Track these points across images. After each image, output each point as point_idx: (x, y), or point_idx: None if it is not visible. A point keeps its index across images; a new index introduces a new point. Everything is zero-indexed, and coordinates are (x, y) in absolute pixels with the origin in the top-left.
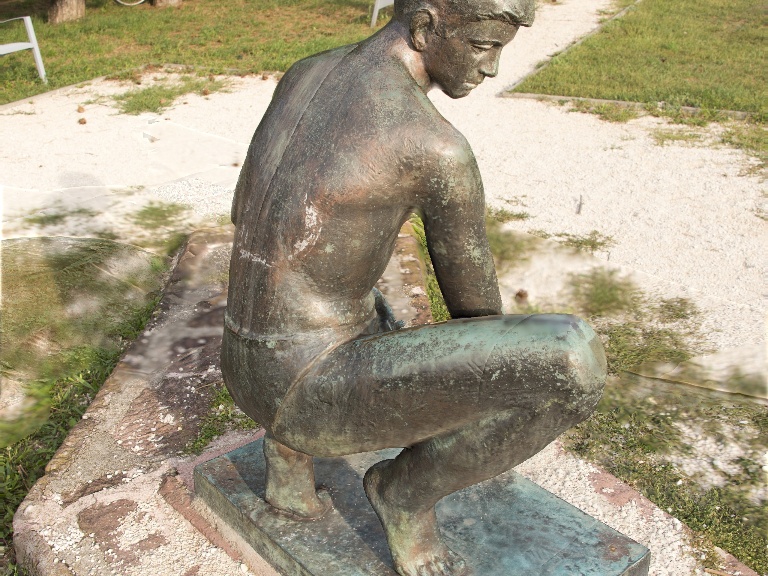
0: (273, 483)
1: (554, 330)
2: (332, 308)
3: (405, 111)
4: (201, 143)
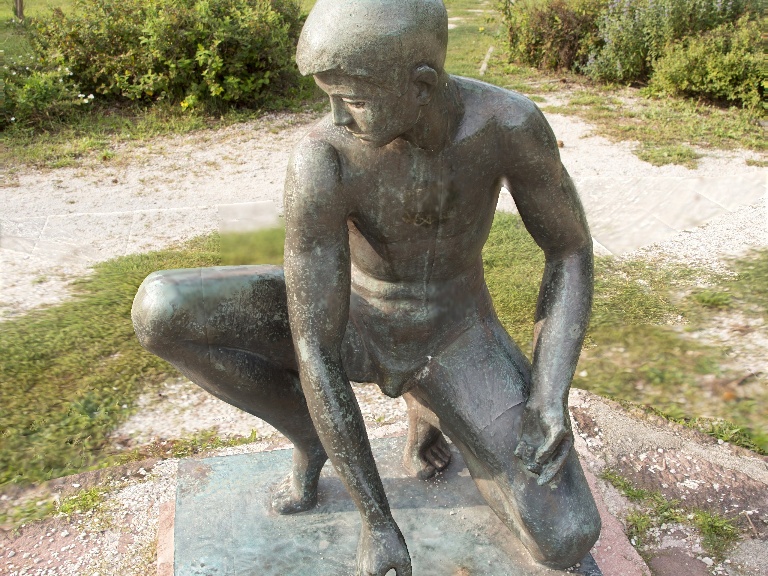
0: None
1: (168, 270)
2: None
3: None
4: None
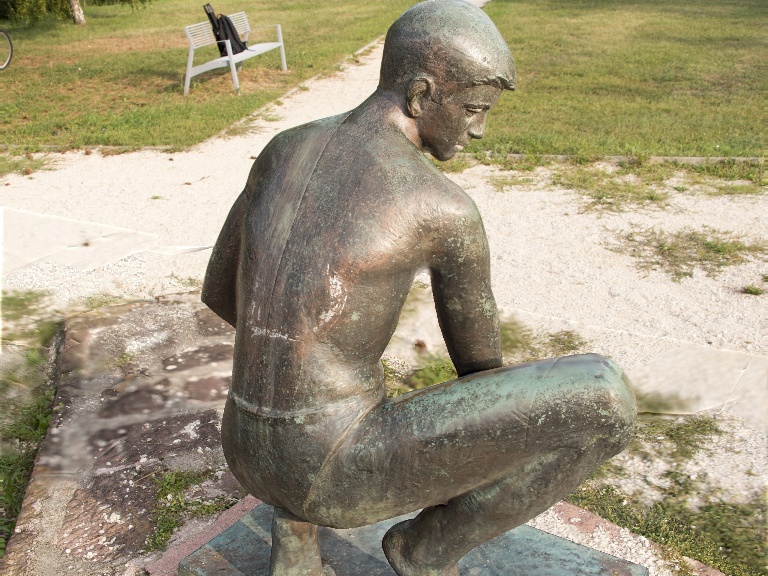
0: (281, 564)
1: (589, 369)
2: (357, 375)
3: (417, 176)
4: (40, 225)
